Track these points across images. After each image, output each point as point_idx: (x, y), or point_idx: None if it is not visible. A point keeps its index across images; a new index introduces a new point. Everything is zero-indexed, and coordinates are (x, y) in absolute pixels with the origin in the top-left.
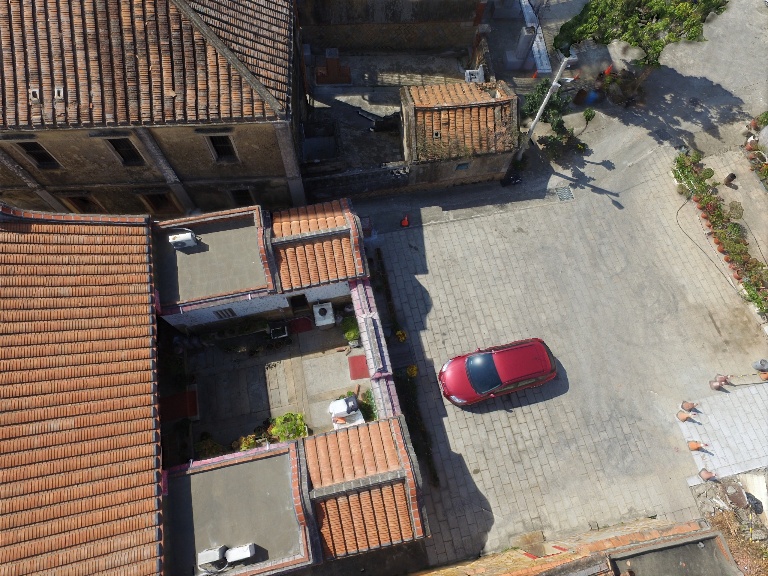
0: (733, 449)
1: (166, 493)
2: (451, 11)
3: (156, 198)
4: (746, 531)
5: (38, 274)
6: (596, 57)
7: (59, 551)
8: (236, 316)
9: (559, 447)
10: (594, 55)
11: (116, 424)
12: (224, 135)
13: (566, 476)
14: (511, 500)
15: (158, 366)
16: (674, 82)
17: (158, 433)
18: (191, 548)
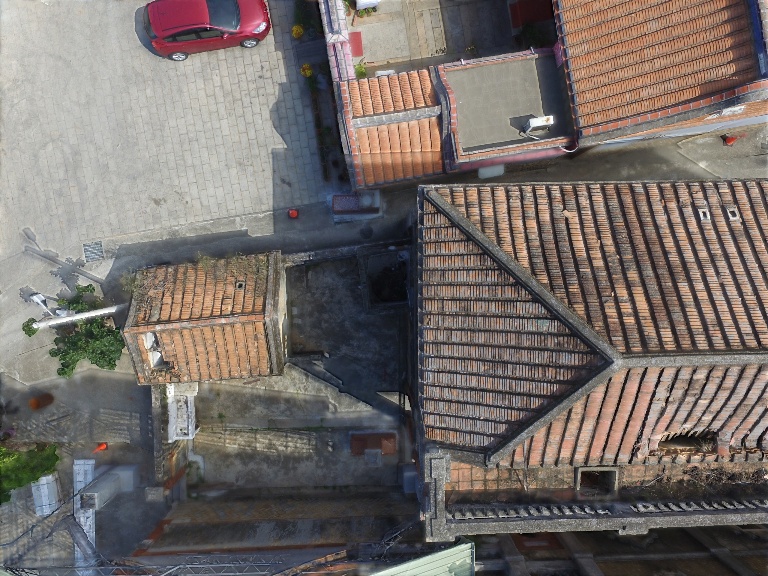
0: None
1: None
2: (200, 532)
3: None
4: None
5: (682, 38)
6: None
7: None
8: None
9: None
10: None
11: None
12: None
13: None
14: None
15: None
16: None
17: None
18: None
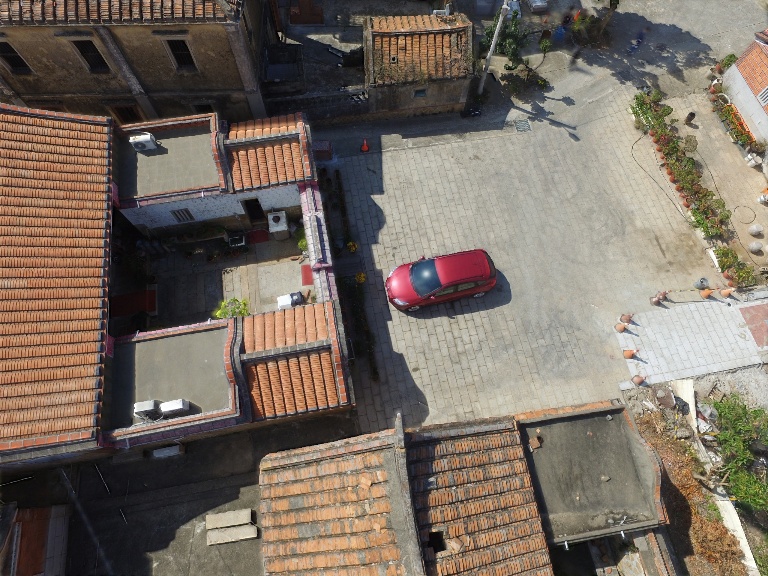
0: (667, 359)
1: (111, 355)
2: None
3: (126, 114)
4: (672, 430)
5: (2, 156)
6: (567, 4)
7: (5, 386)
8: (194, 220)
9: (497, 351)
10: (565, 2)
11: (66, 289)
12: (180, 39)
13: (502, 377)
14: (447, 396)
15: (121, 266)
16: (643, 29)
17: (106, 301)
18: (131, 403)
